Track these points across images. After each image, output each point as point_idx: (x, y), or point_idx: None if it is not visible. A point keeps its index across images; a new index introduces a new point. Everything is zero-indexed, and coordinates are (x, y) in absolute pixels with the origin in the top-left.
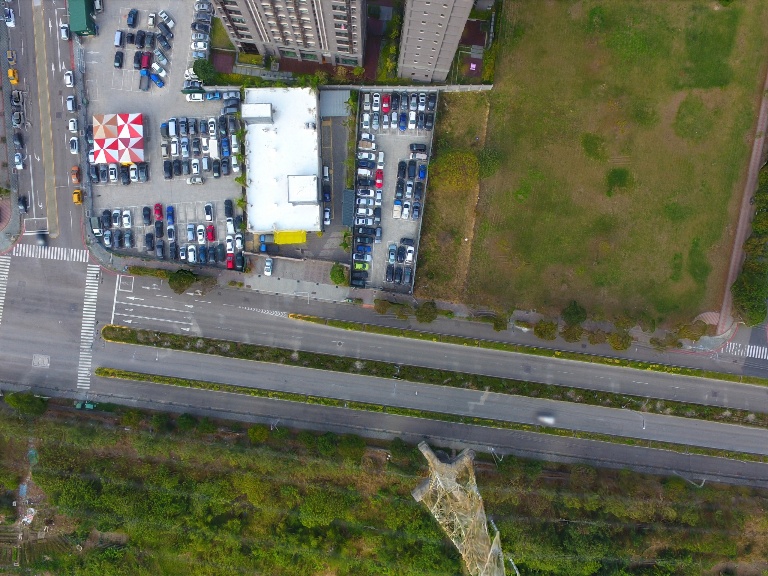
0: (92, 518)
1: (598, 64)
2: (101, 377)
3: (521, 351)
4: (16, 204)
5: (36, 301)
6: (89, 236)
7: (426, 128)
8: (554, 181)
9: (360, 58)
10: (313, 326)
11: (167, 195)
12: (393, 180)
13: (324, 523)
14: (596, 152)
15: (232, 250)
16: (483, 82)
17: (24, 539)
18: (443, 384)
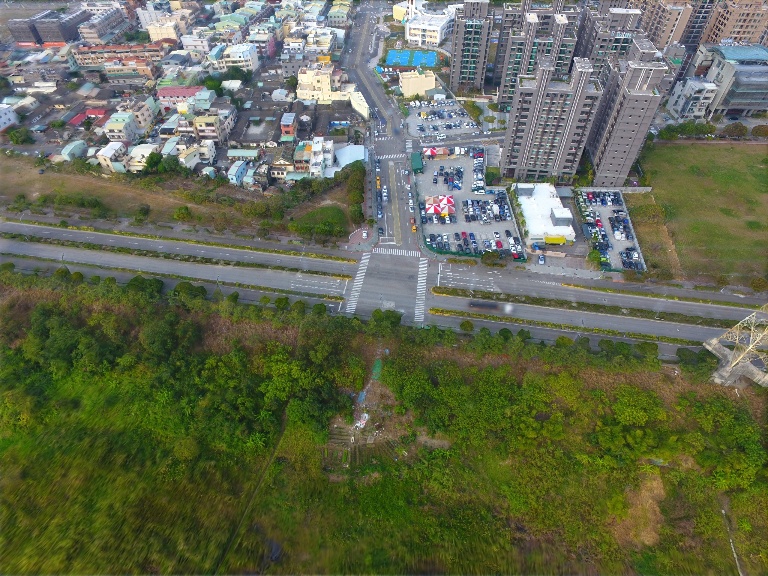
0: (431, 406)
1: (708, 183)
2: (432, 314)
3: (747, 307)
4: (376, 231)
5: (386, 274)
6: (421, 245)
7: (619, 205)
8: (713, 225)
9: (574, 174)
10: (581, 290)
11: (468, 229)
12: (608, 225)
13: (641, 419)
14: (732, 215)
15: (515, 251)
16: (645, 186)
17: (355, 443)
18: (697, 324)
